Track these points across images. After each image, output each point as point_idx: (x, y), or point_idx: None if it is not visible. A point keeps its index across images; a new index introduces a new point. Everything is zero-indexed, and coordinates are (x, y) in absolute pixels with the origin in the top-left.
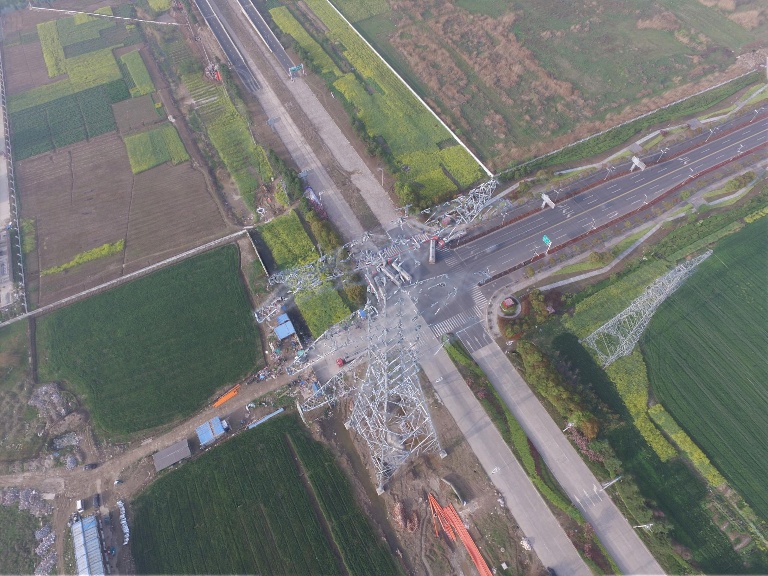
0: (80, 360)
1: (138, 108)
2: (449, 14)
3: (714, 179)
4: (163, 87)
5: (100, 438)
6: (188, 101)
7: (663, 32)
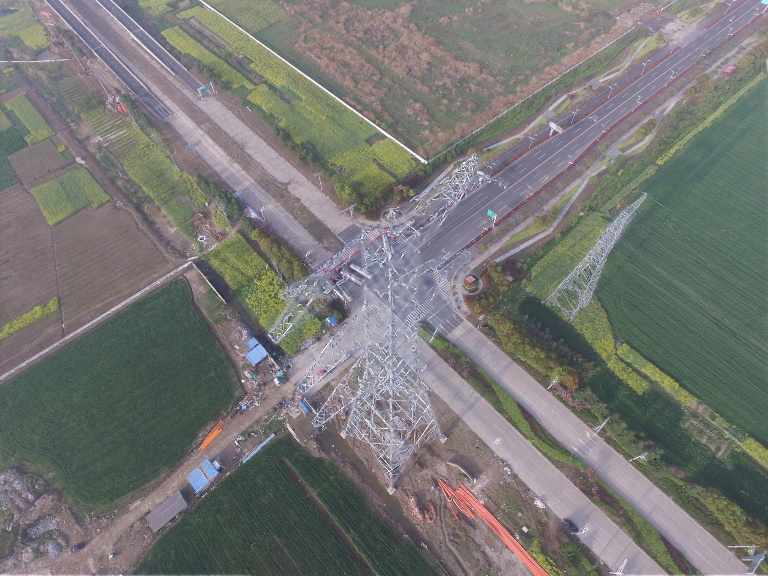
0: (37, 437)
1: (39, 155)
2: (347, 13)
3: (623, 131)
4: (62, 129)
5: (81, 514)
6: (94, 139)
7: (548, 4)
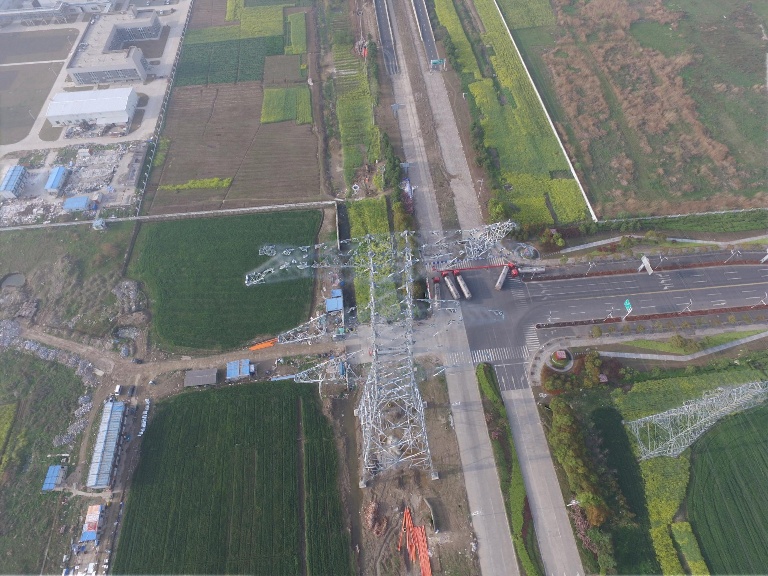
0: (161, 270)
1: (286, 65)
2: (617, 42)
3: None
4: (314, 51)
5: (153, 340)
6: (330, 69)
7: None
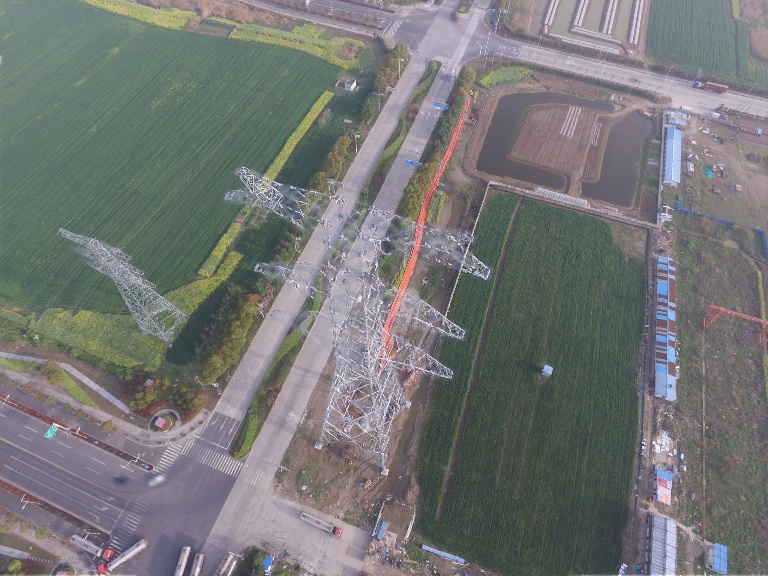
0: None
1: None
2: None
3: None
4: None
5: None
6: None
7: None
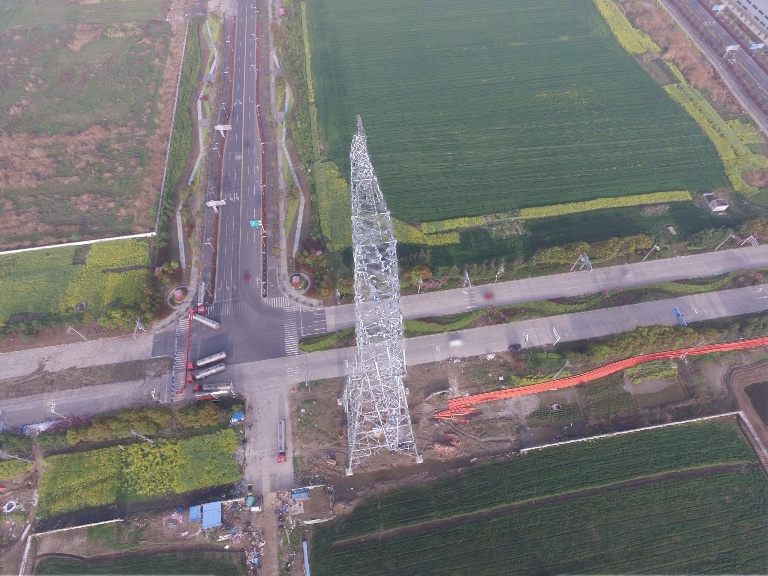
0: None
1: None
2: None
3: (267, 97)
4: None
5: None
6: None
7: (98, 41)
